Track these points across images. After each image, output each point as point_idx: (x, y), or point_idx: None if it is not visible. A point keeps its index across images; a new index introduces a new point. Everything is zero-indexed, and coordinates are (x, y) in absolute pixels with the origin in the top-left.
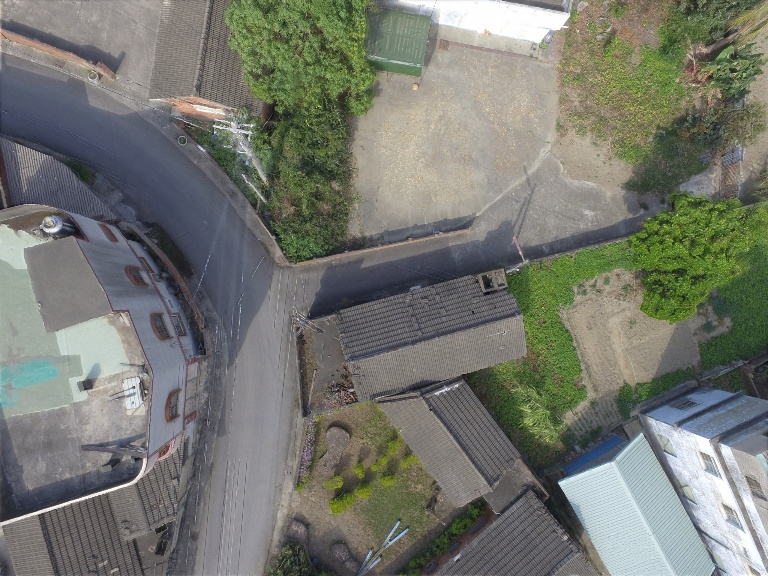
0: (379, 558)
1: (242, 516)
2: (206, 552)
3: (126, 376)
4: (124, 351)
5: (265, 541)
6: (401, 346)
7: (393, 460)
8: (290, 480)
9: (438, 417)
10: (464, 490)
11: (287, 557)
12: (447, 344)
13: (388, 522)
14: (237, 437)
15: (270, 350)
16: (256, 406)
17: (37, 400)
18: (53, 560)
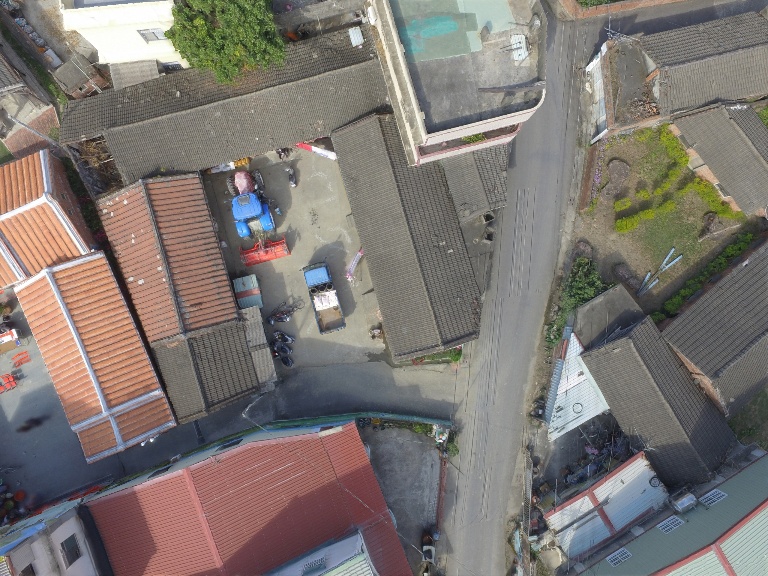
0: (657, 279)
1: (531, 239)
2: (500, 269)
3: (513, 33)
4: (511, 12)
5: (552, 262)
6: (708, 56)
7: (667, 193)
8: (572, 210)
9: (738, 125)
10: (757, 196)
11: (582, 266)
12: (747, 58)
13: (663, 249)
14: (526, 169)
15: (555, 93)
16: (543, 142)
17: (441, 49)
18: (410, 228)
